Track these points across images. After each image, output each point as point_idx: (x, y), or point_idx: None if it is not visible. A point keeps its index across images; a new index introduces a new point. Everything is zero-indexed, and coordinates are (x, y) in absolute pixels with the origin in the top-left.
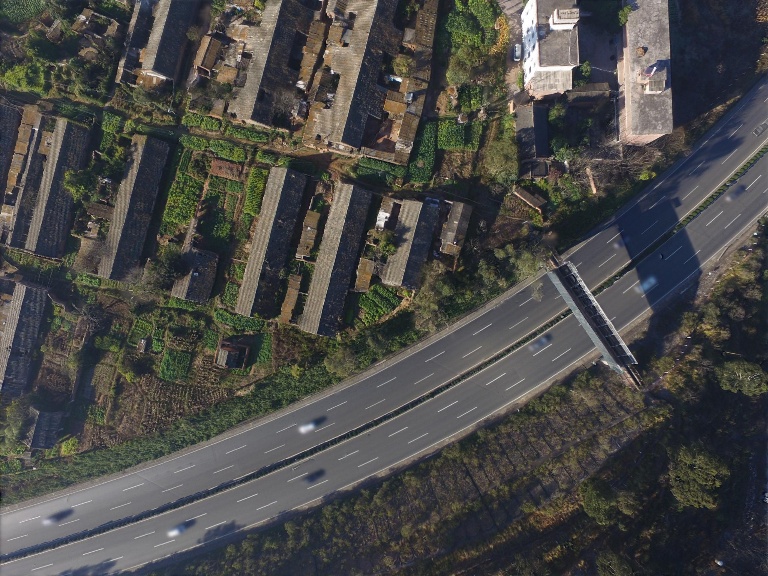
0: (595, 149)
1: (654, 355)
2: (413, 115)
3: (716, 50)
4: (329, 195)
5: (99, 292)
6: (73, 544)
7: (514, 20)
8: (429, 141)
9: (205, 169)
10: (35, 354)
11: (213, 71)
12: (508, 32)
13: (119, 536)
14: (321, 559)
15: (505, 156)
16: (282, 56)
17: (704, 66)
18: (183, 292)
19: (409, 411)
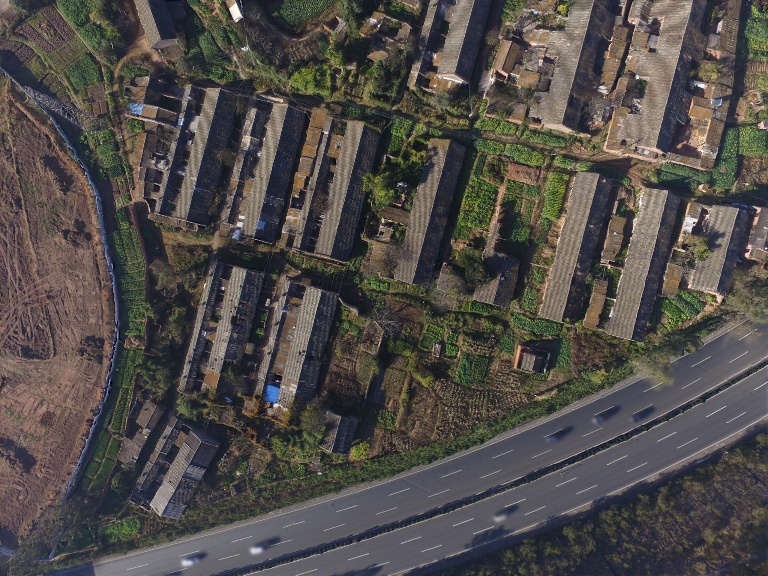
0: None
1: None
2: (719, 121)
3: None
4: (631, 200)
5: (388, 296)
6: (338, 549)
7: None
8: (731, 147)
9: (500, 173)
10: (325, 358)
11: (510, 75)
12: None
13: (385, 541)
14: (617, 565)
15: None
16: (589, 61)
17: None
18: (489, 297)
19: (677, 416)
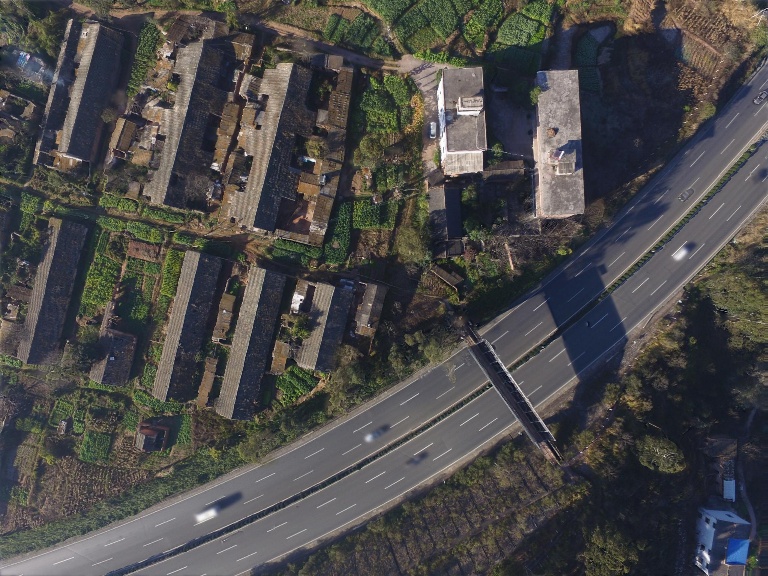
0: (514, 224)
1: (576, 428)
2: (327, 197)
3: (638, 119)
4: (245, 276)
5: (20, 373)
6: None
7: (430, 97)
8: (344, 221)
9: (123, 250)
10: None
11: (129, 153)
12: (423, 110)
13: None
14: None
15: (411, 245)
16: (195, 139)
17: (626, 135)
18: (100, 377)
19: (337, 482)
